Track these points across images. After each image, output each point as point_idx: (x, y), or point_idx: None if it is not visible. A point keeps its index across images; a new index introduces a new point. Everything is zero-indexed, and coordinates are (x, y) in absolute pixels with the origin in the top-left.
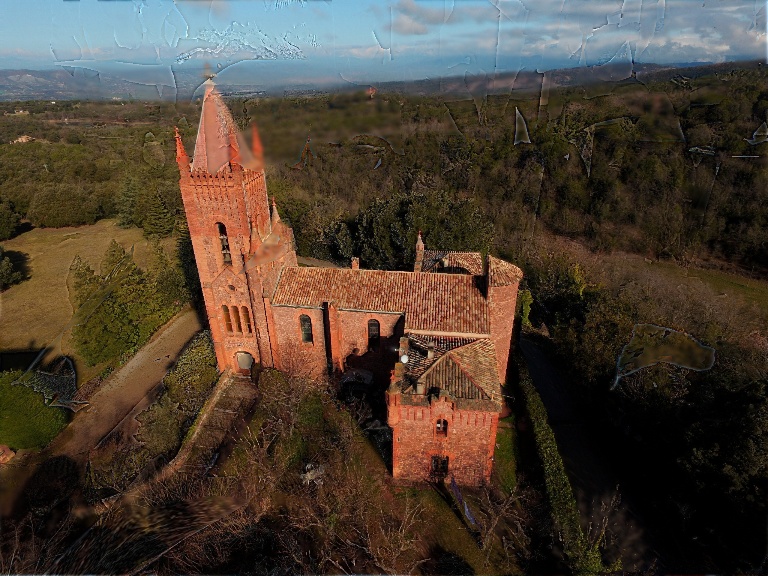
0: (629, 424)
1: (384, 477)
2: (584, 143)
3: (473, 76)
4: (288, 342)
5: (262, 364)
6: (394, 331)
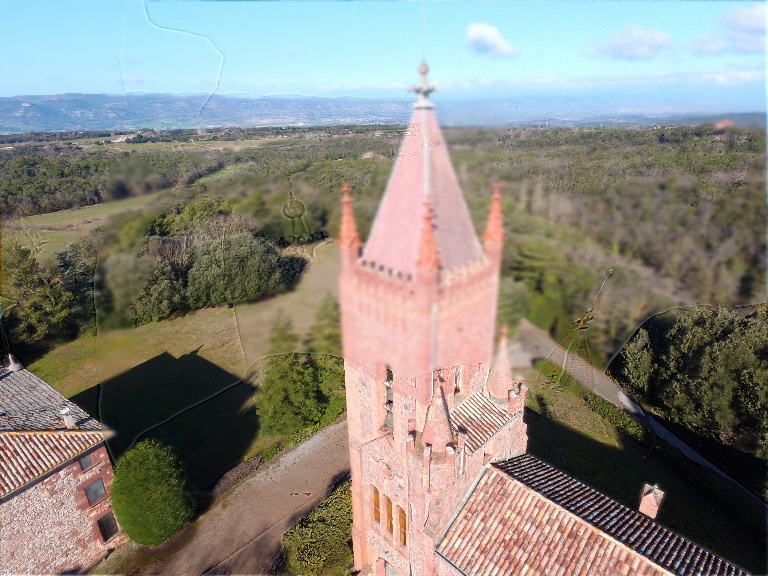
0: None
1: None
2: None
3: None
4: None
5: None
6: None
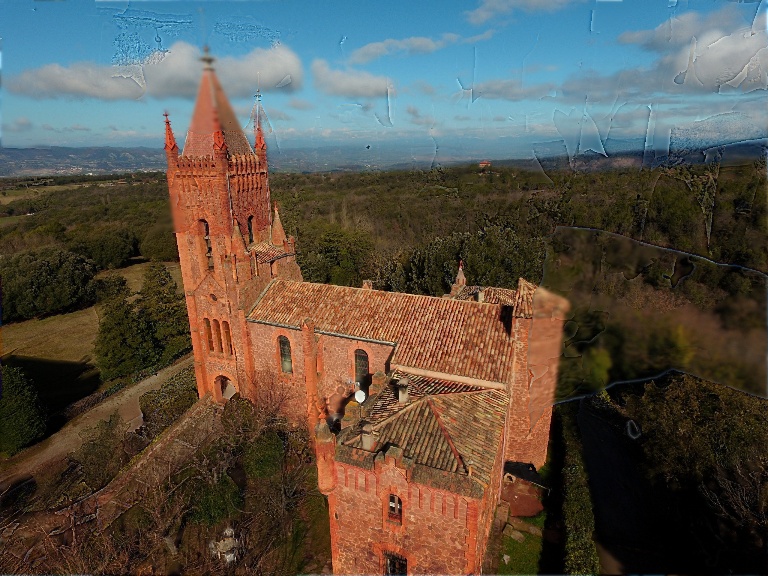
0: (735, 567)
1: (321, 571)
2: (705, 190)
3: (567, 119)
4: (266, 369)
5: (239, 394)
6: (386, 368)
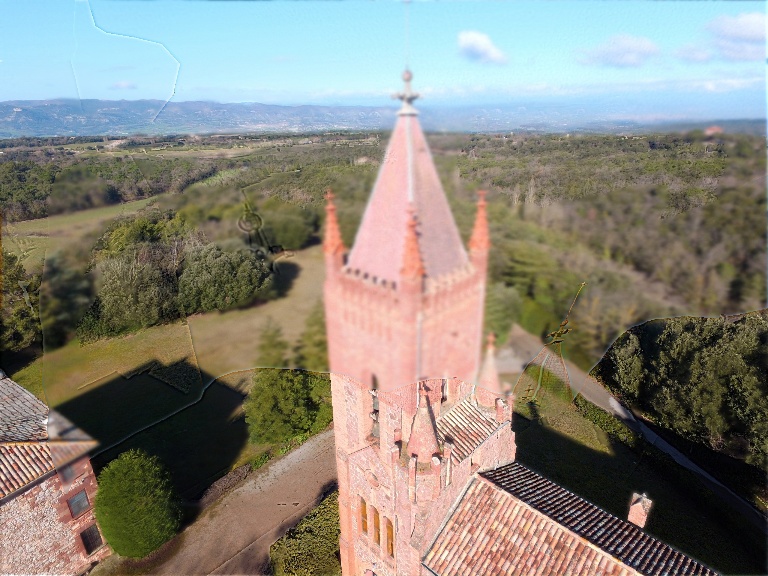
0: None
1: None
2: None
3: None
4: None
5: None
6: None
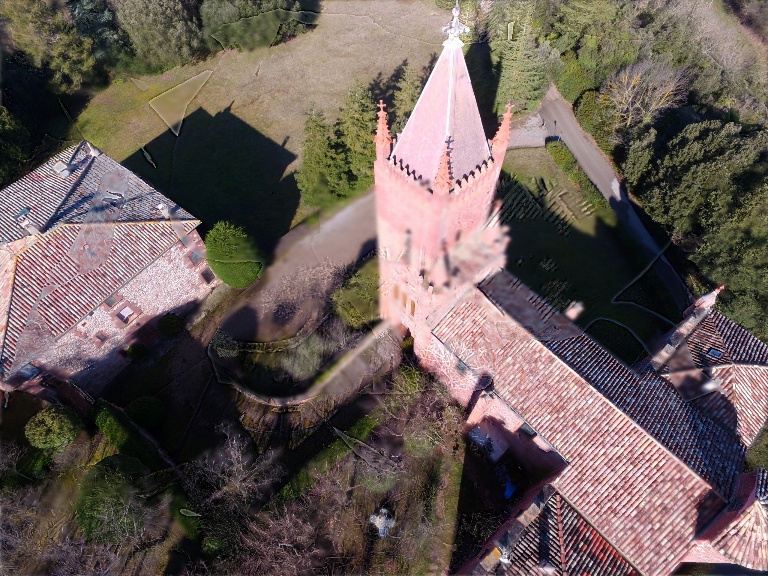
0: None
1: (440, 574)
2: None
3: None
4: None
5: None
6: (550, 452)
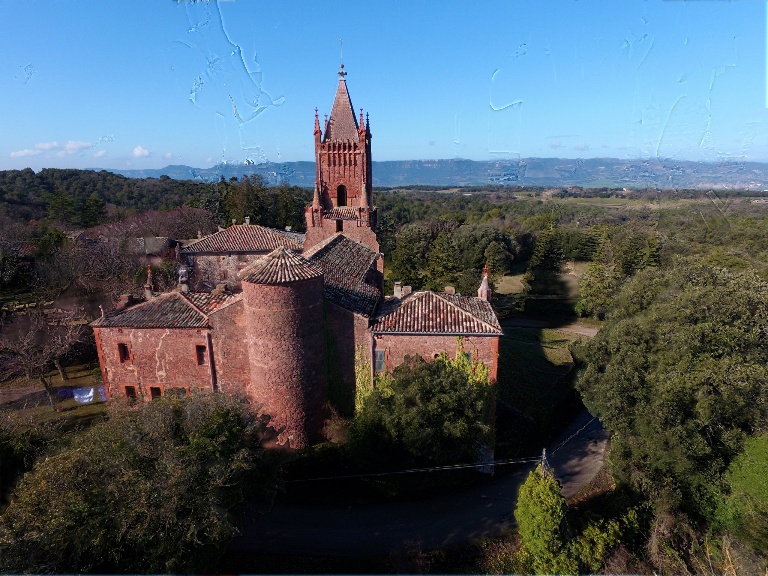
0: None
1: None
2: None
3: None
4: None
5: None
6: None
